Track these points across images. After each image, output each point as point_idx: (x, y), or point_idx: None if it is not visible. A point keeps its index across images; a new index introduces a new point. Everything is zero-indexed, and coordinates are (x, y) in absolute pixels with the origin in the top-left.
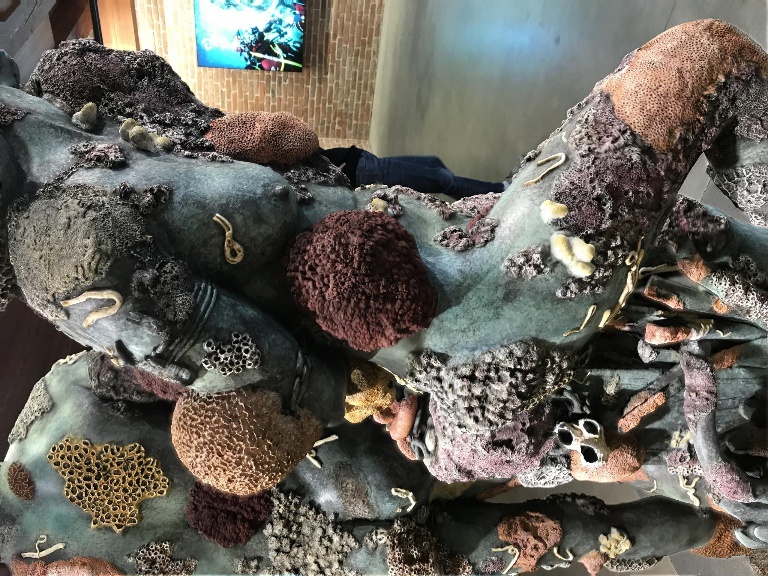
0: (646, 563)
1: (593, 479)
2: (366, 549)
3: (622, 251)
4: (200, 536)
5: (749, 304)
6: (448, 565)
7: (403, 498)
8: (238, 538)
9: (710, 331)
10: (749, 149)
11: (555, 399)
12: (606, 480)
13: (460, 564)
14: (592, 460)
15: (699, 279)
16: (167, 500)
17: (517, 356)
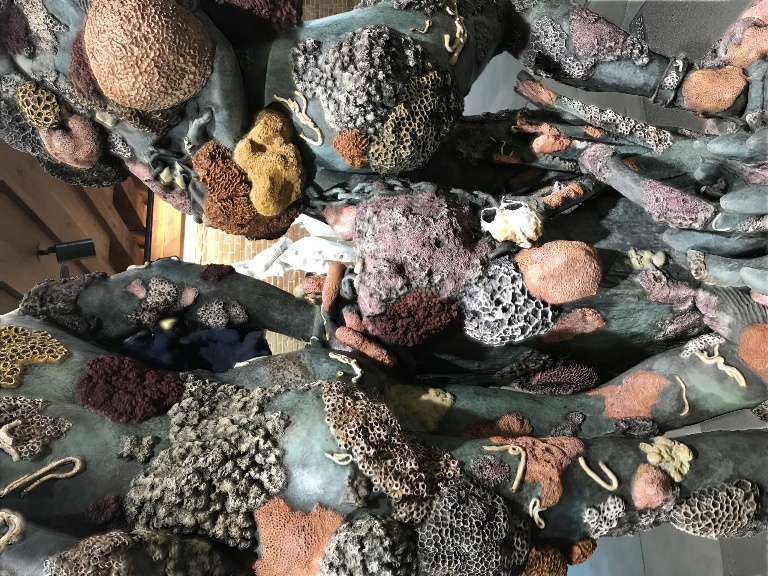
0: (736, 488)
1: (547, 270)
2: (295, 391)
3: (439, 0)
4: (85, 409)
5: (611, 117)
6: (420, 450)
7: (344, 364)
8: (133, 414)
9: (593, 144)
10: (530, 14)
11: (473, 205)
12: (559, 261)
13: (439, 457)
14: (517, 207)
15: (553, 100)
16: (58, 369)
17: (372, 28)
